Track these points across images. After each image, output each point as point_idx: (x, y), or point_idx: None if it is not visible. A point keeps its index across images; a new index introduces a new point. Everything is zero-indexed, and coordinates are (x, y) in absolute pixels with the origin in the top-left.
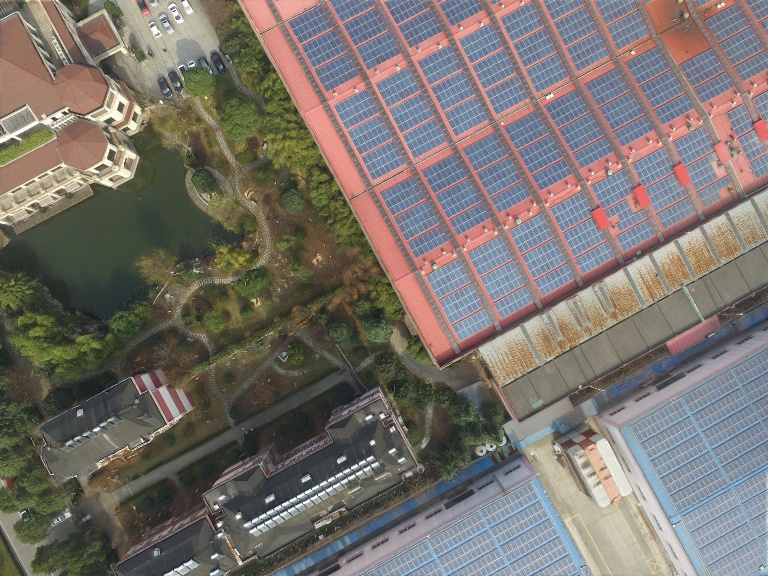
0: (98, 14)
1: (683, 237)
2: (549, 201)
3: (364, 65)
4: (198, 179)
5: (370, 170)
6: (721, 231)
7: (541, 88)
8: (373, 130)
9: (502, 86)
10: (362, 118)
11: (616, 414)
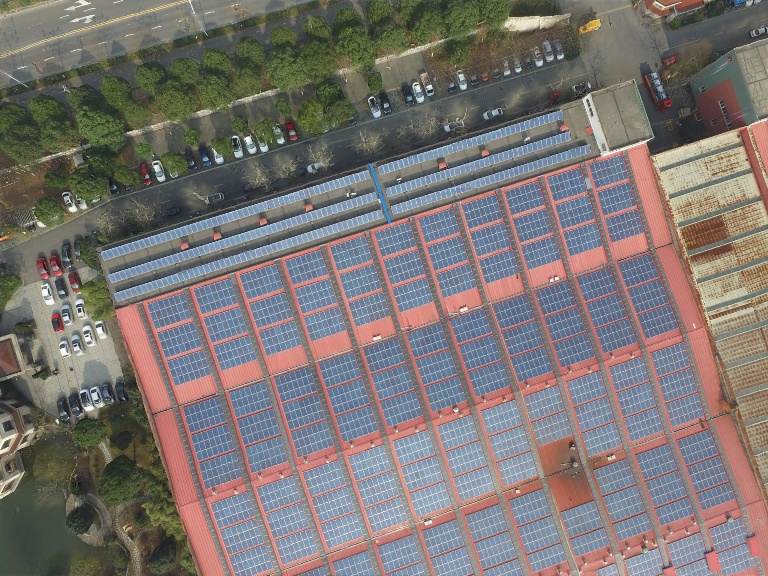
0: (5, 338)
1: None
2: None
3: (249, 466)
4: (69, 530)
5: (236, 570)
6: None
7: (421, 513)
8: (246, 532)
9: (383, 506)
10: (237, 519)
11: None
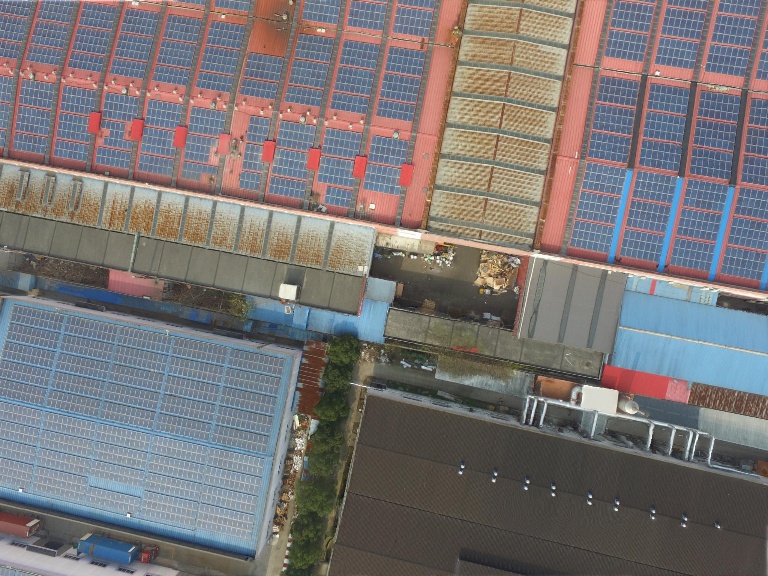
0: None
1: (168, 197)
2: (67, 79)
3: None
4: None
5: None
6: (200, 216)
7: None
8: None
9: None
10: None
11: (31, 297)
